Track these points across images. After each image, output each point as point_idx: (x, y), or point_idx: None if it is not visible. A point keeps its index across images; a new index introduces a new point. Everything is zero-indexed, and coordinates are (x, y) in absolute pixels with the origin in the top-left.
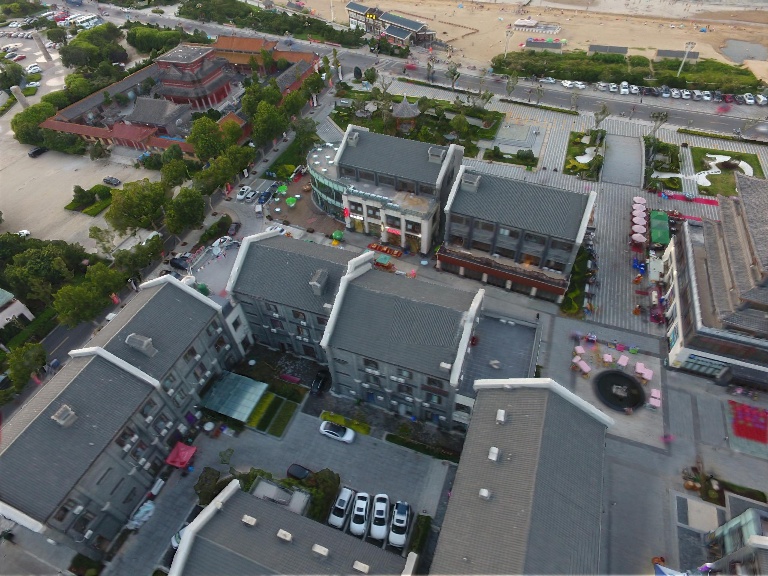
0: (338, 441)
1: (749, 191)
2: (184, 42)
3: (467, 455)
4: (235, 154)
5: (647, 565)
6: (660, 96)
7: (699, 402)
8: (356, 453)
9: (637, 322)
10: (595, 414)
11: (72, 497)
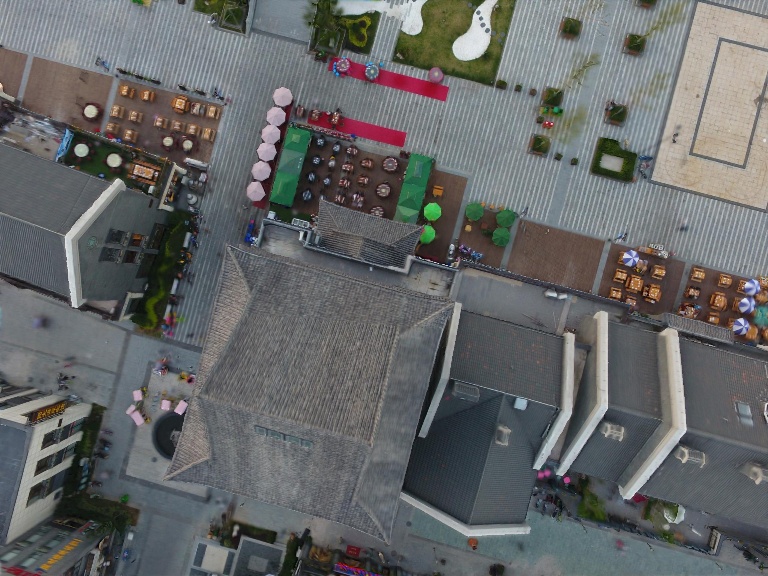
0: None
1: (225, 299)
2: None
3: None
4: None
5: None
6: None
7: None
8: None
9: None
10: None
11: None
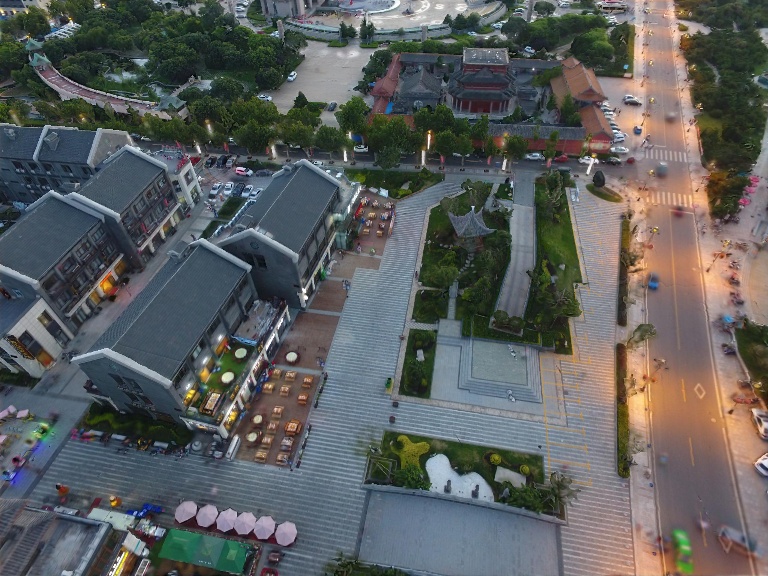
0: None
1: None
2: (573, 56)
3: None
4: (321, 132)
5: None
6: None
7: None
8: None
9: (49, 489)
10: None
11: None
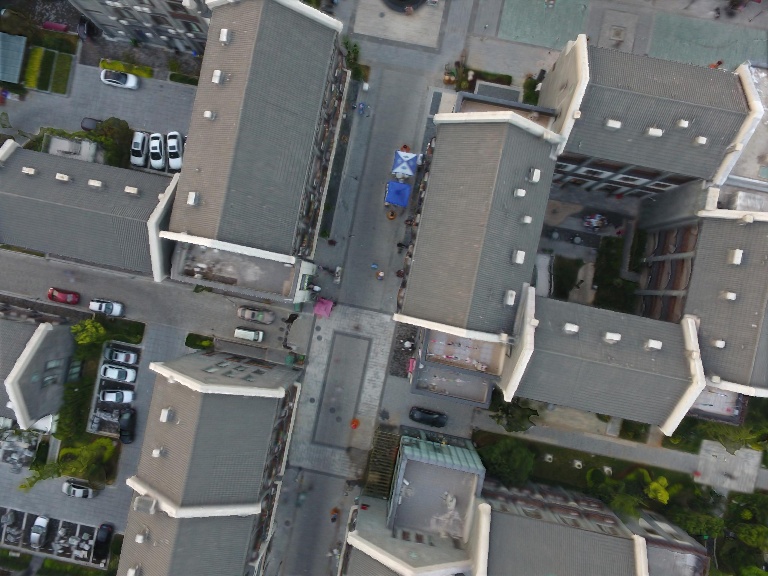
0: (124, 89)
1: None
2: None
3: (201, 82)
4: None
5: None
6: None
7: None
8: (144, 98)
9: None
10: (319, 19)
11: None
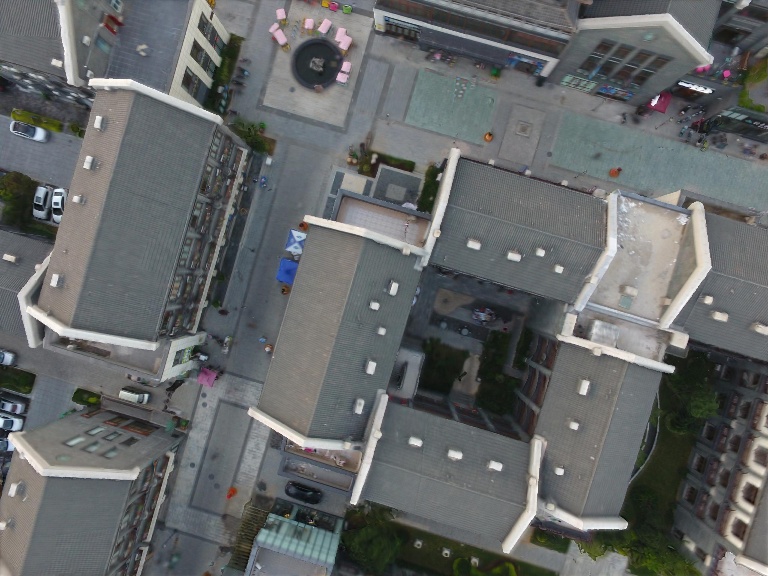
0: (33, 141)
1: None
2: None
3: (79, 162)
4: None
5: (295, 229)
6: None
7: (395, 72)
8: (53, 151)
9: None
10: None
11: None
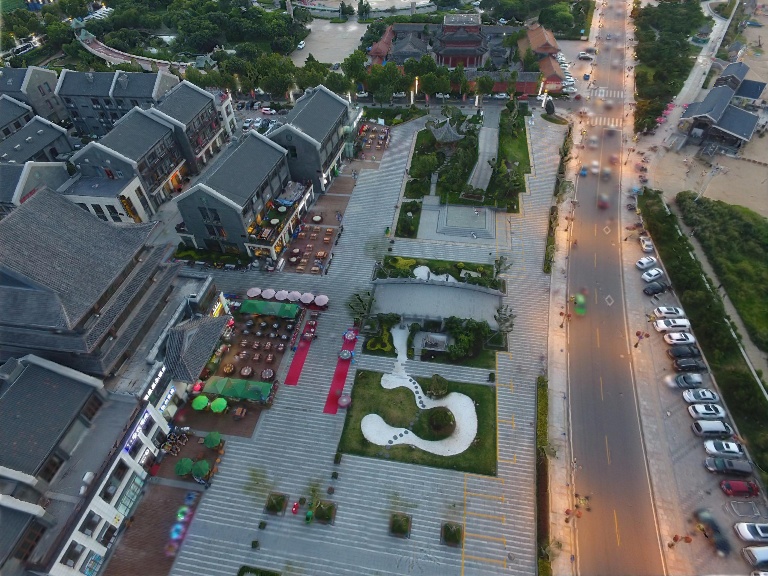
0: None
1: None
2: (537, 22)
3: None
4: None
5: None
6: (678, 374)
7: None
8: None
9: None
10: None
11: (71, 99)
